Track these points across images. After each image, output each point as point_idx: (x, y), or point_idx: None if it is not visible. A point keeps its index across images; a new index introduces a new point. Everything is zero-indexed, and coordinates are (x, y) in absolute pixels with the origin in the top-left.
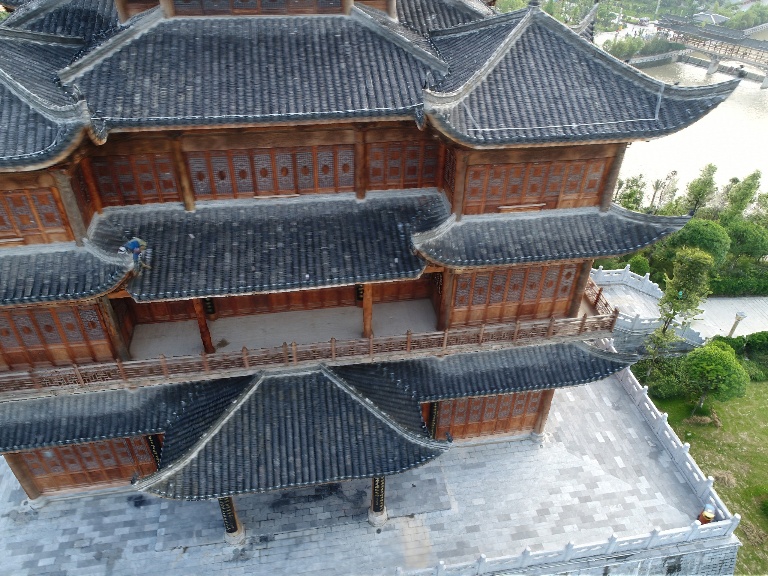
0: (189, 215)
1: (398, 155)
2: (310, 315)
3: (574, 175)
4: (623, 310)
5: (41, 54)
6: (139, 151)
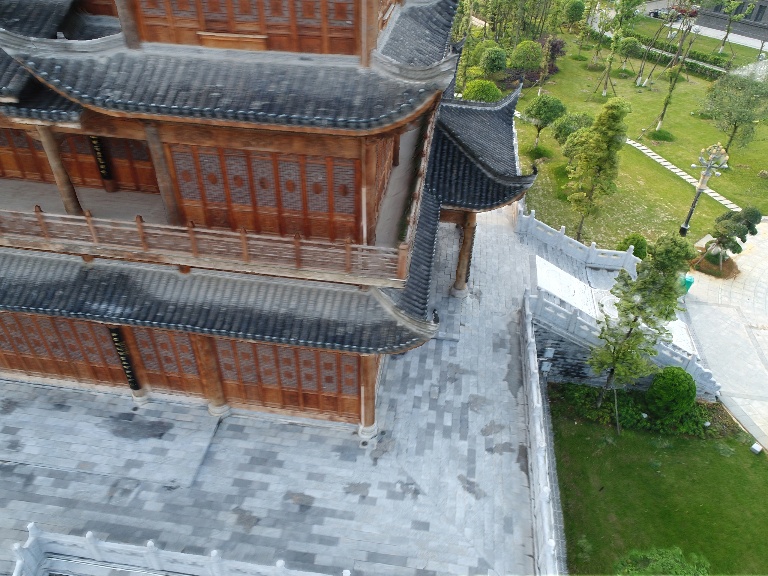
0: None
1: None
2: None
3: None
4: None
5: None
6: None
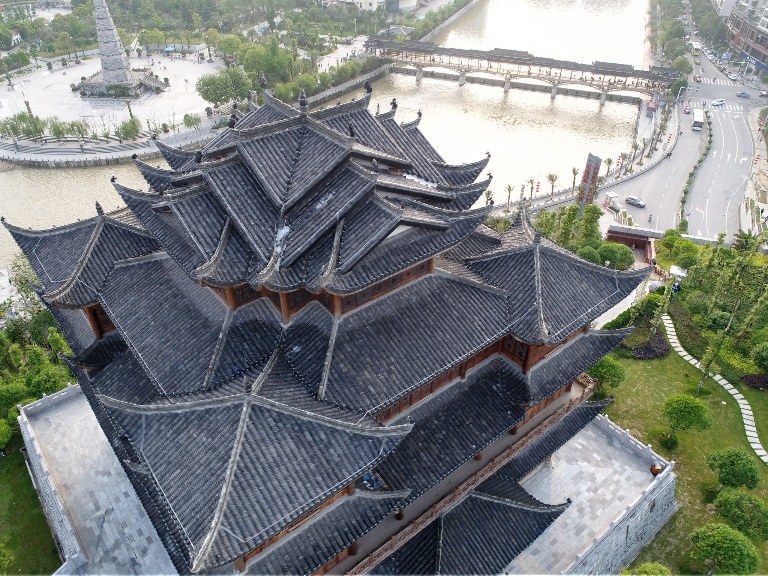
0: None
1: None
2: None
3: None
4: None
5: (281, 379)
6: None
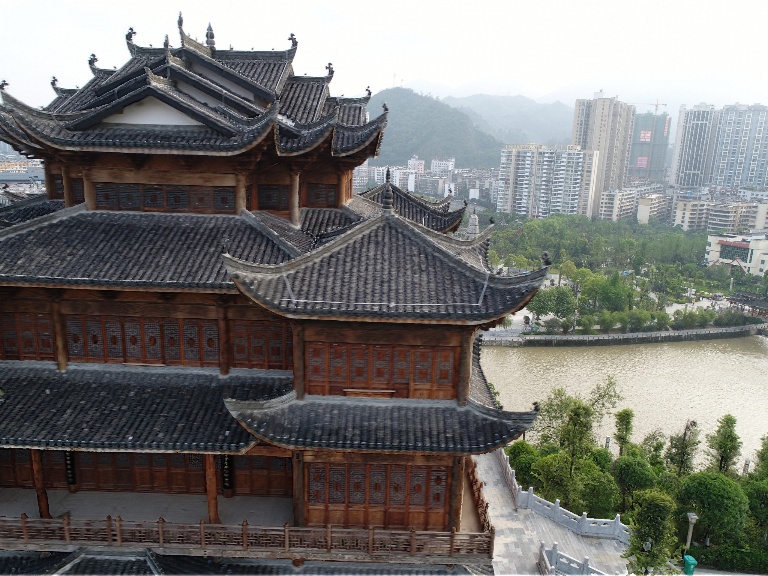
0: (57, 374)
1: (261, 334)
2: (171, 499)
3: (422, 363)
4: (609, 569)
5: None
6: (23, 310)
